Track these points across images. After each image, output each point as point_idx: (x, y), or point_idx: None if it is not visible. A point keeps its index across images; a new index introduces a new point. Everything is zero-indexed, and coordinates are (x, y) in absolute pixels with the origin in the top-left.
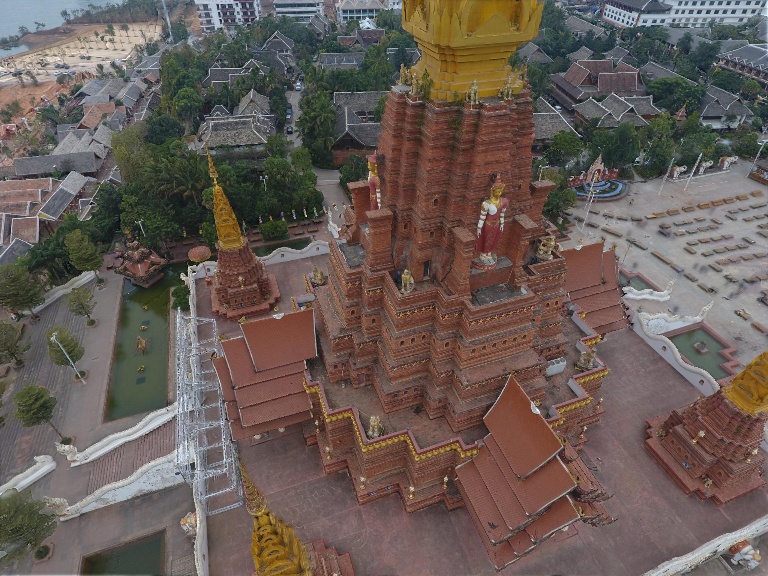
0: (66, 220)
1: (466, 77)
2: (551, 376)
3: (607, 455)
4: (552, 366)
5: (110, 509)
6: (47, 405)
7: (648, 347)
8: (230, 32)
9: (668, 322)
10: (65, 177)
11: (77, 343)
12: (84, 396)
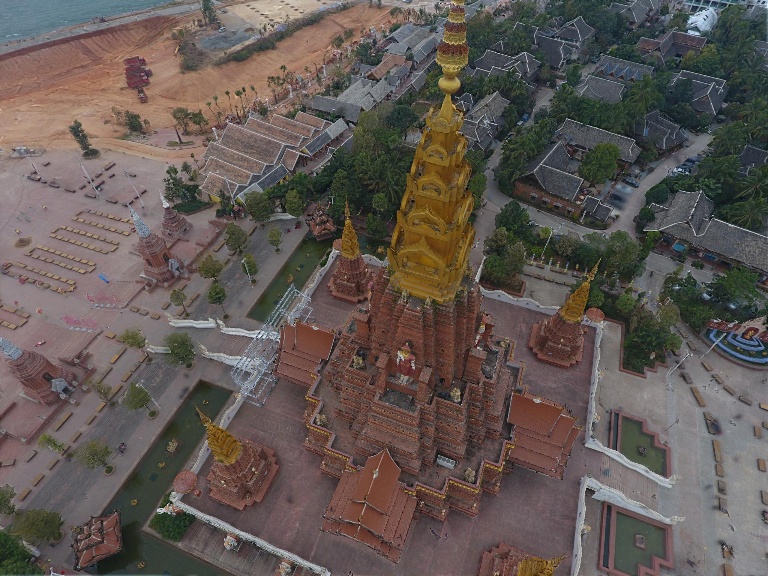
0: (296, 177)
1: (411, 281)
2: (443, 466)
3: (454, 537)
4: (442, 461)
5: (221, 364)
6: (221, 298)
7: (575, 504)
8: None
9: (626, 502)
10: (337, 119)
11: (255, 266)
12: (248, 295)
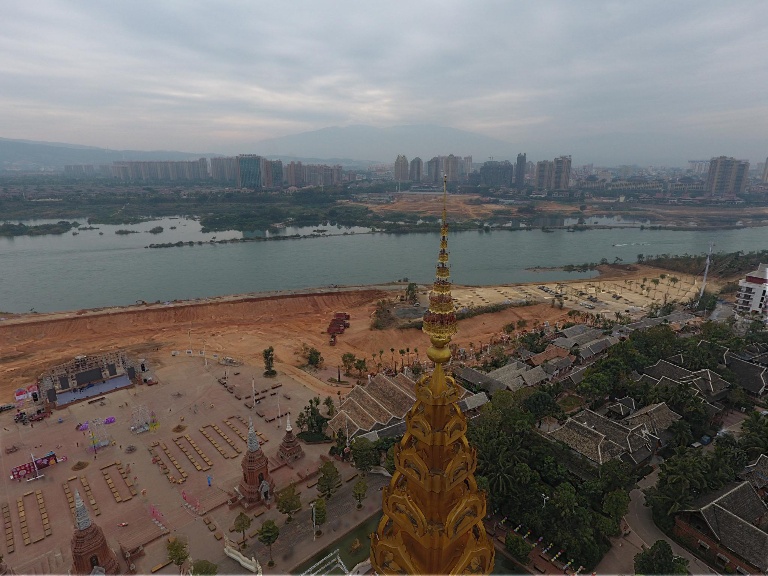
0: None
1: None
2: None
3: None
4: None
5: None
6: (271, 538)
7: None
8: (744, 324)
9: None
10: (480, 392)
11: (324, 515)
12: (305, 547)
